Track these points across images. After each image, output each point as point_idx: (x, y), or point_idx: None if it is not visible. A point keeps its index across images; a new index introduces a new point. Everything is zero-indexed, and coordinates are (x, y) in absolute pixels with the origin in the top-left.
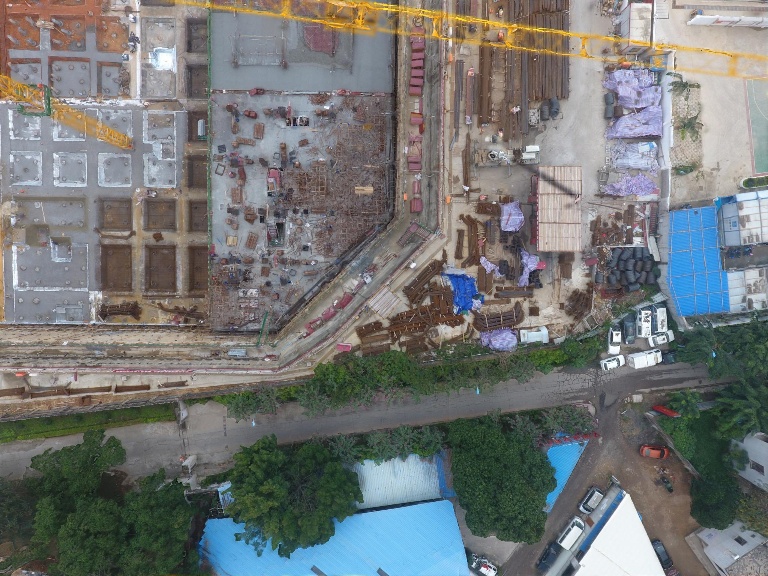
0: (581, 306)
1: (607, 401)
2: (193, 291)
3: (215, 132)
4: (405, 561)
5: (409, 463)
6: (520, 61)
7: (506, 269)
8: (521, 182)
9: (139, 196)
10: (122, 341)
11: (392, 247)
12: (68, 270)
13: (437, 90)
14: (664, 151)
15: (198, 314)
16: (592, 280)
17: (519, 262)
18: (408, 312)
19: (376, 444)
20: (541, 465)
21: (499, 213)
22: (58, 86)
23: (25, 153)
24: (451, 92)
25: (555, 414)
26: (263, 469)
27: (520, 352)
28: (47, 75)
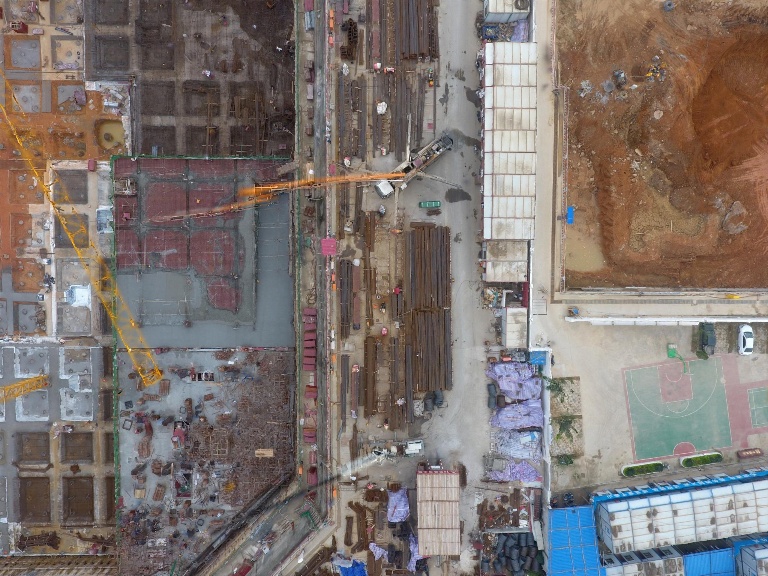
0: None
1: None
2: (111, 520)
3: (122, 389)
4: None
5: None
6: (404, 355)
7: (393, 559)
8: (408, 468)
9: (56, 430)
10: None
11: (290, 514)
12: None
13: (324, 383)
14: (545, 442)
15: None
16: (479, 564)
17: (408, 546)
18: None
19: None
20: None
21: (387, 500)
22: None
23: None
24: (337, 385)
25: None
26: None
27: None
28: None
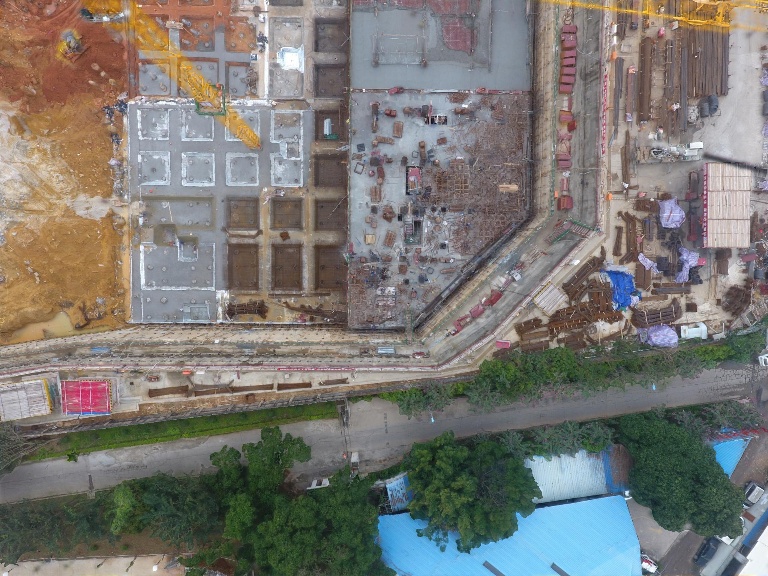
0: (741, 302)
1: (764, 396)
2: (319, 290)
3: (354, 131)
4: (580, 556)
5: (576, 459)
6: (680, 58)
7: (667, 265)
8: (679, 179)
9: (266, 195)
10: (271, 339)
11: (539, 244)
12: (194, 269)
13: (597, 88)
14: None
15: (324, 312)
16: (750, 276)
17: (676, 258)
18: (568, 309)
19: (546, 440)
20: (711, 460)
21: (657, 210)
22: (186, 86)
23: (153, 153)
24: (611, 90)
25: (721, 409)
26: (449, 465)
27: (683, 348)
28: (176, 75)
